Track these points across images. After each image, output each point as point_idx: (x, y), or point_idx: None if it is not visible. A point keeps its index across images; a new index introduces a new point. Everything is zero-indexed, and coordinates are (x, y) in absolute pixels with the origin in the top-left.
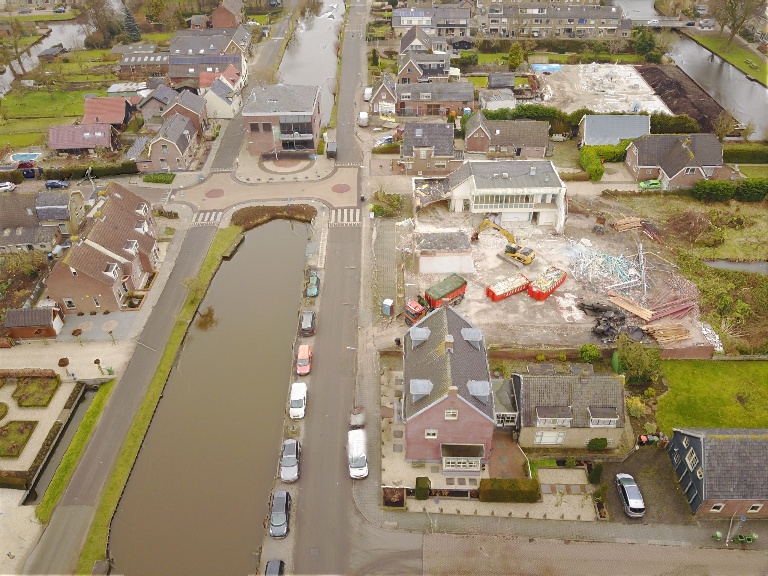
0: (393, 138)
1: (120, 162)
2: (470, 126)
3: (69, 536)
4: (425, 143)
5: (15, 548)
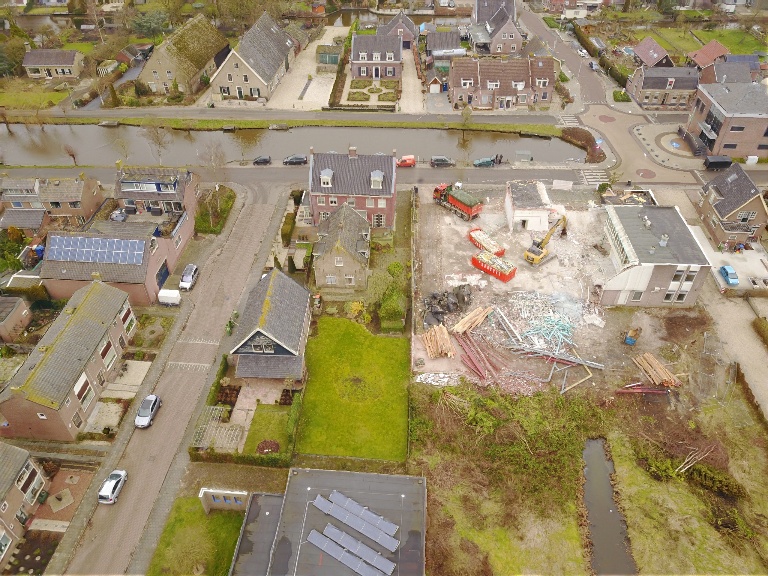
0: None
1: (622, 72)
2: None
3: (300, 116)
4: (724, 190)
5: None
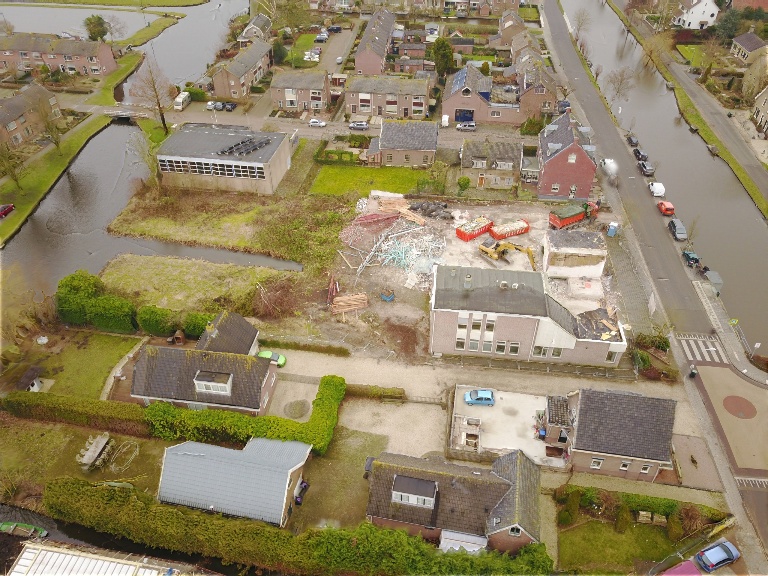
0: (698, 508)
1: None
2: (535, 496)
3: (742, 156)
4: None
5: (766, 156)
